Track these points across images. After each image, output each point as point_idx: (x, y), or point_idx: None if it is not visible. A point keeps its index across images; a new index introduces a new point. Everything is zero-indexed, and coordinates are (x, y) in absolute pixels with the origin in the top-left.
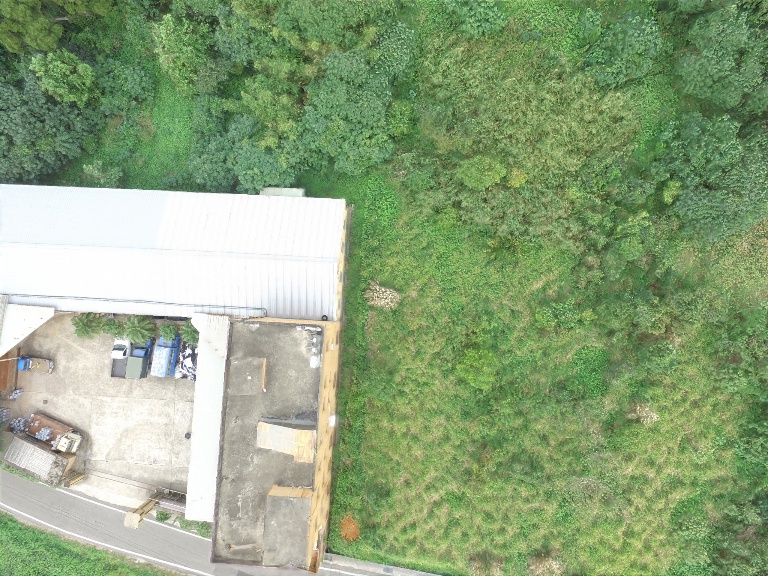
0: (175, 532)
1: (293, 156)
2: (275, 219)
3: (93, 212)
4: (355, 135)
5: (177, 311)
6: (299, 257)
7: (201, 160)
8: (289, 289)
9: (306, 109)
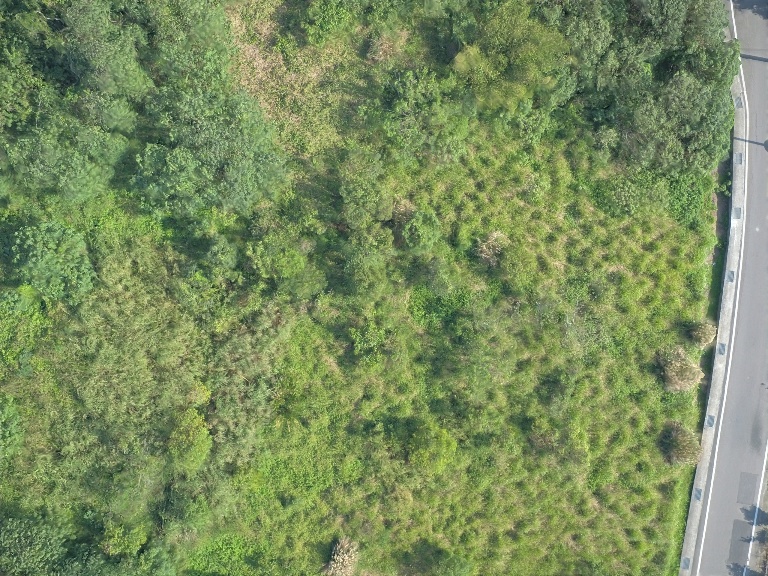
0: None
1: None
2: None
3: None
4: None
5: None
6: None
7: None
8: None
9: None
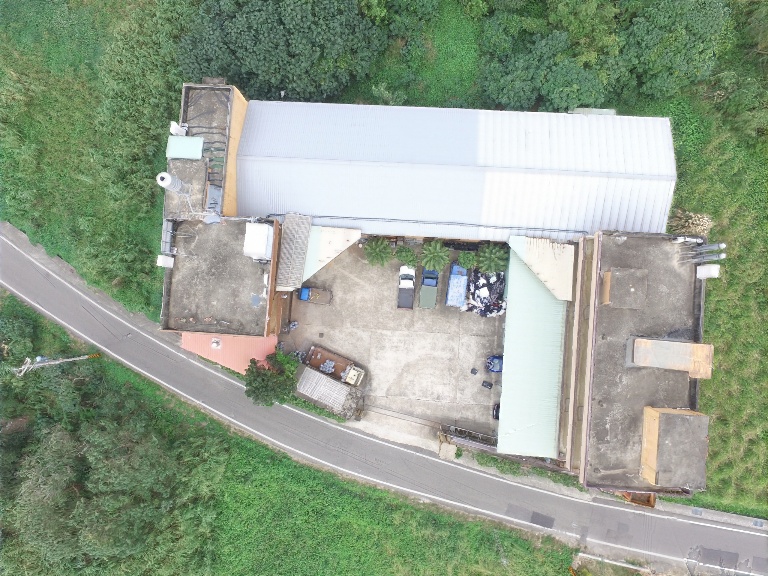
0: (462, 471)
1: (613, 72)
2: (599, 137)
3: (402, 130)
4: (688, 48)
5: (490, 234)
6: (634, 175)
7: (512, 77)
8: (617, 210)
9: (635, 21)
